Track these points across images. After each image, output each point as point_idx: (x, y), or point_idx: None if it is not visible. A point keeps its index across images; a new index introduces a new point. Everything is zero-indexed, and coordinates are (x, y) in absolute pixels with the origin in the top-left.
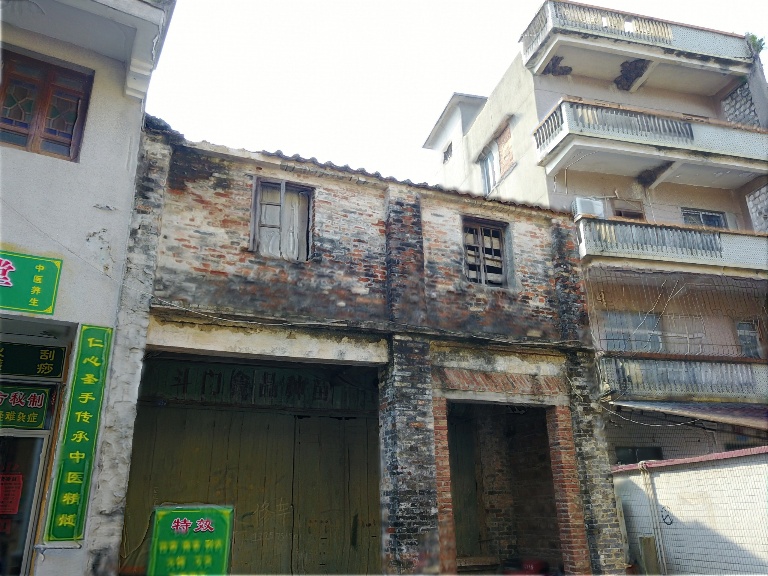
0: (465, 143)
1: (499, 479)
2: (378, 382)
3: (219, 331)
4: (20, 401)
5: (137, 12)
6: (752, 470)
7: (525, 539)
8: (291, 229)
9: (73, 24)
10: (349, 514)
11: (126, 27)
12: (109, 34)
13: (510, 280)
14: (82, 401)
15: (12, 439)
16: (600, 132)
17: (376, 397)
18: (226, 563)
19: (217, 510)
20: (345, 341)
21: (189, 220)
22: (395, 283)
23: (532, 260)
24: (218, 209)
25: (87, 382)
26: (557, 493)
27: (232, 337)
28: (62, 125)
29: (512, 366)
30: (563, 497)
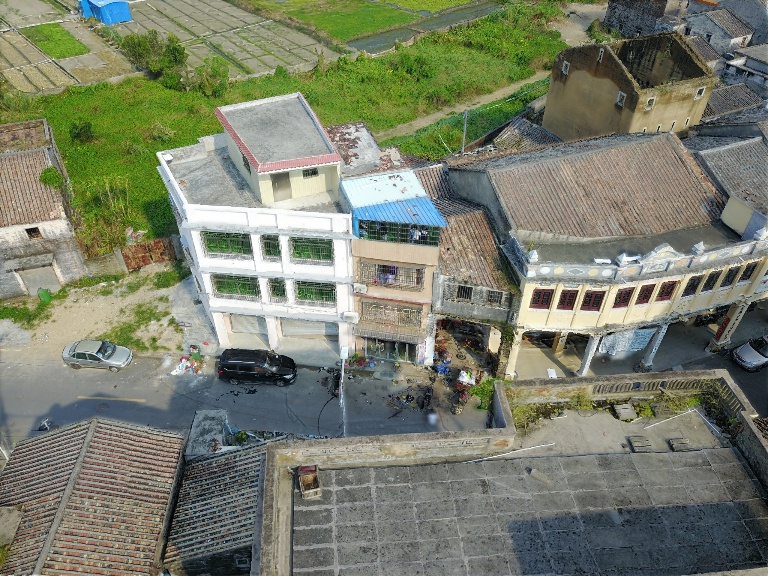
0: None
1: None
2: None
3: None
4: None
5: None
6: None
7: None
8: None
9: None
10: None
11: None
12: None
13: None
14: None
15: None
16: None
17: None
18: None
19: None
20: None
21: None
22: None
23: None
24: None
25: None
26: None
27: None
28: None
29: None
30: None
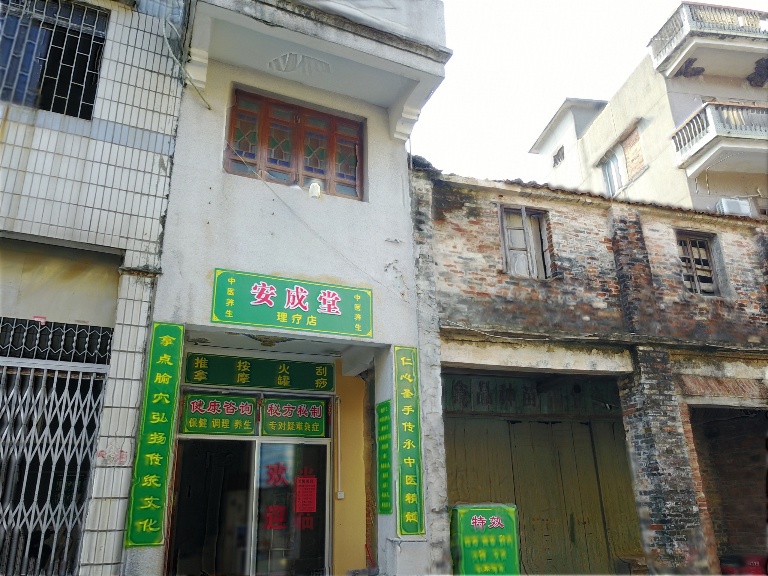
0: (580, 147)
1: (704, 479)
2: (618, 389)
3: (492, 347)
4: (304, 412)
5: (425, 67)
6: None
7: (739, 537)
8: (528, 250)
9: (357, 80)
10: (565, 513)
11: (411, 80)
12: (383, 86)
13: (723, 289)
14: (405, 413)
15: (304, 446)
16: (748, 133)
17: (578, 402)
18: (518, 556)
19: (504, 508)
20: (594, 353)
21: (452, 247)
22: (631, 297)
23: (742, 269)
24: (473, 236)
25: (406, 396)
26: None
27: (503, 352)
28: (347, 169)
29: (740, 371)
30: None
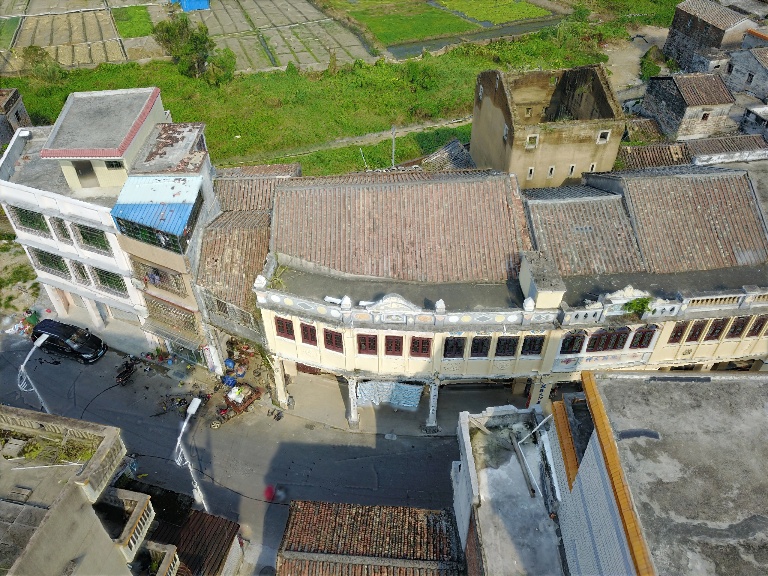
0: None
1: None
2: None
3: None
4: None
5: None
6: None
7: None
8: None
9: None
10: None
11: None
12: None
13: None
14: None
15: None
16: None
17: None
18: None
19: None
20: None
21: None
22: None
23: None
24: None
25: None
26: None
27: None
28: None
29: None
30: None
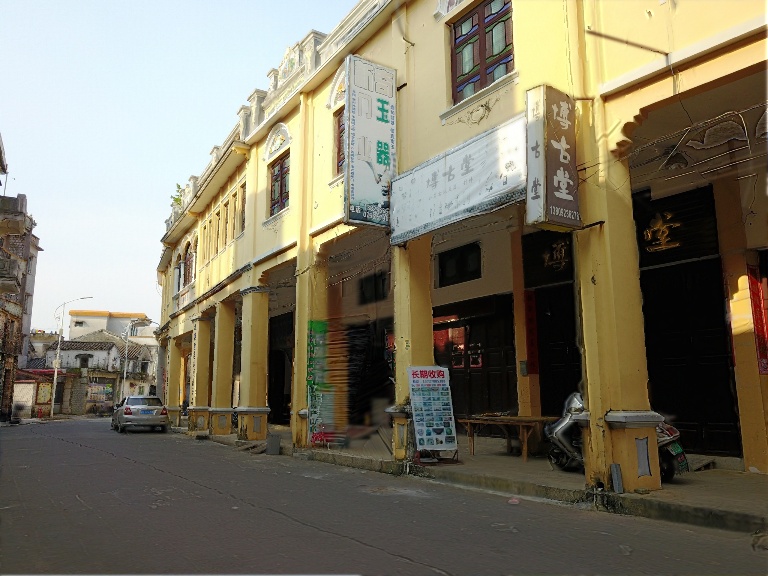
0: None
1: None
2: None
3: None
4: None
5: None
6: (23, 386)
7: None
8: None
9: None
10: None
11: None
12: None
13: (10, 337)
14: None
15: None
16: None
17: None
18: None
19: None
20: None
21: None
22: None
23: None
24: None
25: None
26: (6, 390)
27: None
28: None
29: None
30: (8, 391)
